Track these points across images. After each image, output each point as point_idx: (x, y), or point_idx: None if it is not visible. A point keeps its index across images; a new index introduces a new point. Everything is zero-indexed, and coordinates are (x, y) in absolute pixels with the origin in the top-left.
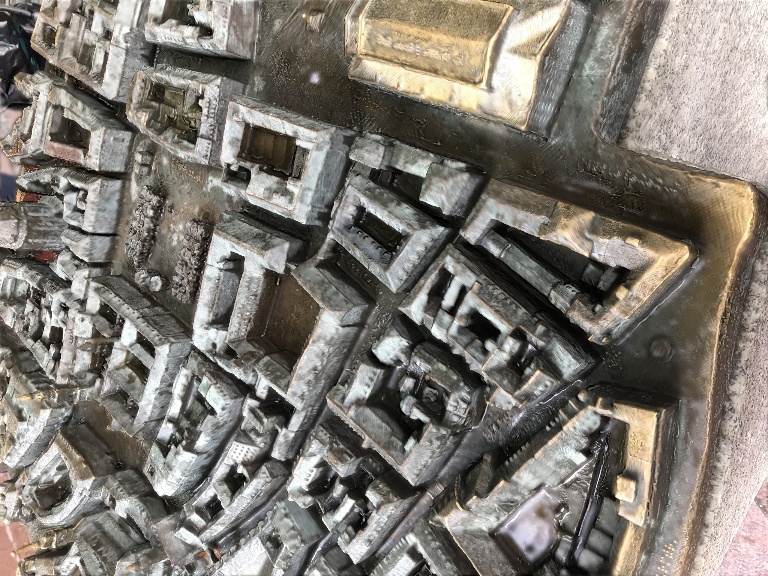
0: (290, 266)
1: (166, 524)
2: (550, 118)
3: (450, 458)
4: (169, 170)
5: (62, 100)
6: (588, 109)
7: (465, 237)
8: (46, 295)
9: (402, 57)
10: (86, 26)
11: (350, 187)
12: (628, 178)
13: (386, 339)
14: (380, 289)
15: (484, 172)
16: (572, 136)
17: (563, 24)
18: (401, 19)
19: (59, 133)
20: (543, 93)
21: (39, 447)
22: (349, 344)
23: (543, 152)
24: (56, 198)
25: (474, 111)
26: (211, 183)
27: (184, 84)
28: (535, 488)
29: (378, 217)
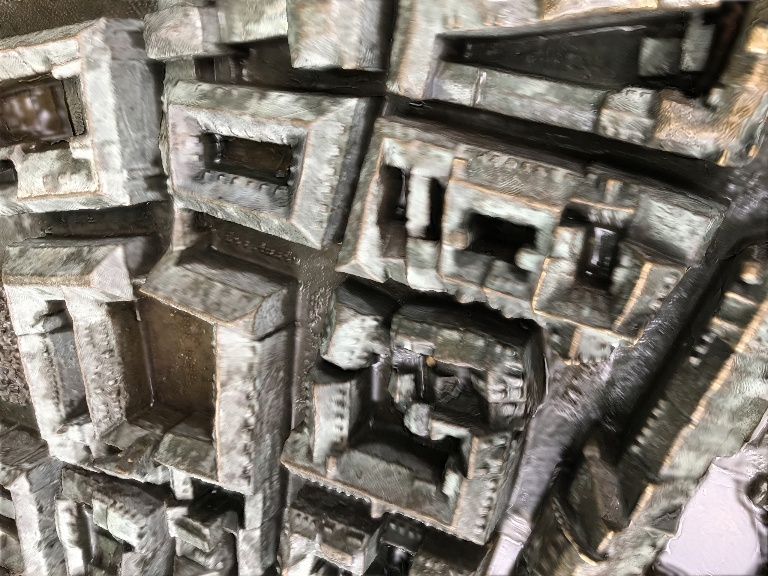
0: (140, 282)
1: None
2: None
3: (517, 471)
4: None
5: None
6: None
7: (401, 91)
8: None
9: None
10: None
11: (172, 107)
12: None
13: (338, 329)
14: (294, 257)
15: None
16: None
17: None
18: None
19: None
20: None
21: None
22: (283, 362)
23: None
24: None
25: None
26: None
27: None
28: (704, 471)
29: (239, 137)
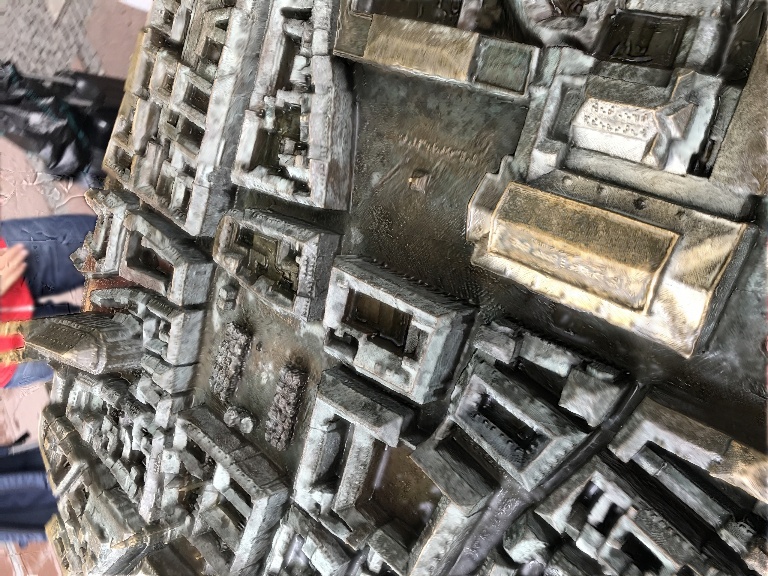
0: (404, 441)
1: None
2: (710, 334)
3: None
4: (255, 307)
5: (138, 226)
6: (754, 327)
7: (616, 455)
8: (124, 415)
9: (542, 264)
10: (162, 154)
11: (475, 376)
12: None
13: (522, 542)
14: (504, 472)
15: (627, 373)
16: (735, 352)
17: (734, 252)
18: (542, 228)
19: (135, 257)
20: (709, 318)
21: (121, 564)
22: (471, 527)
23: (699, 363)
24: (132, 318)
25: (626, 327)
26: (304, 328)
27: (277, 236)
28: None
29: (507, 409)
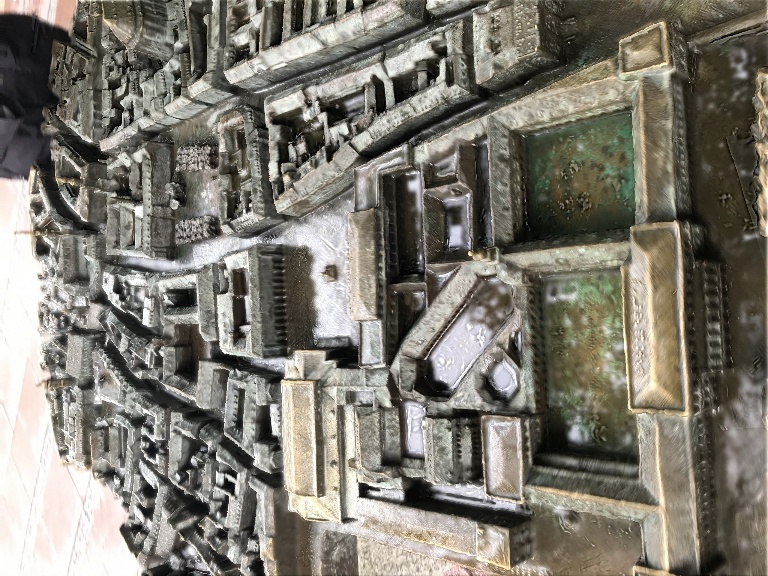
0: None
1: (97, 306)
2: None
3: None
4: None
5: None
6: (331, 525)
7: None
8: None
9: None
10: None
11: (246, 385)
12: (311, 557)
13: (204, 441)
14: None
15: None
16: None
17: None
18: (295, 418)
19: (201, 4)
20: None
21: None
22: None
23: None
24: None
25: None
26: None
27: None
28: None
29: None
